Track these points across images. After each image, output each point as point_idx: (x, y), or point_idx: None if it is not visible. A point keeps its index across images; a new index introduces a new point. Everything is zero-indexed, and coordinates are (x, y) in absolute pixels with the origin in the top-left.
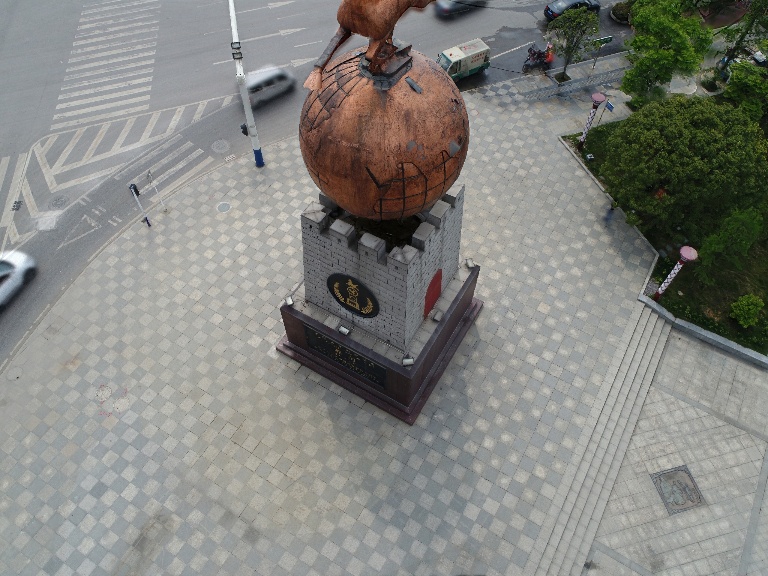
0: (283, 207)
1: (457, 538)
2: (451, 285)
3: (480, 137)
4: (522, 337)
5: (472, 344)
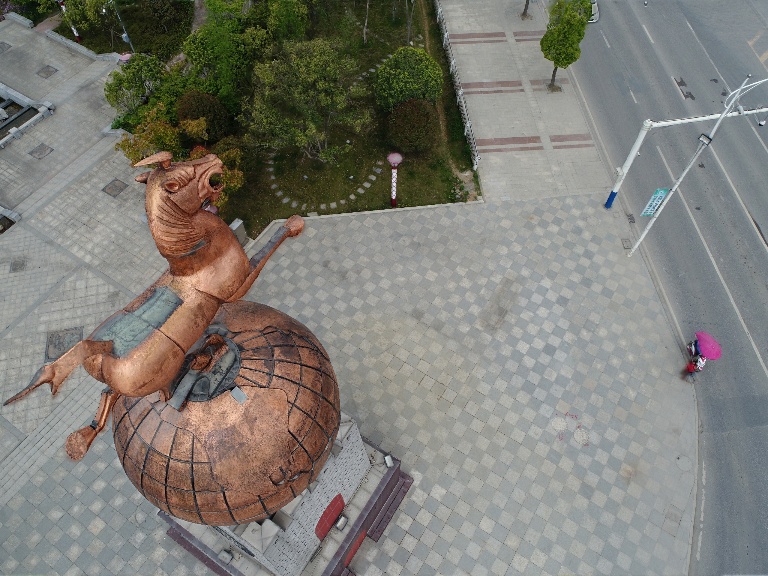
0: None
1: None
2: None
3: None
4: None
5: None
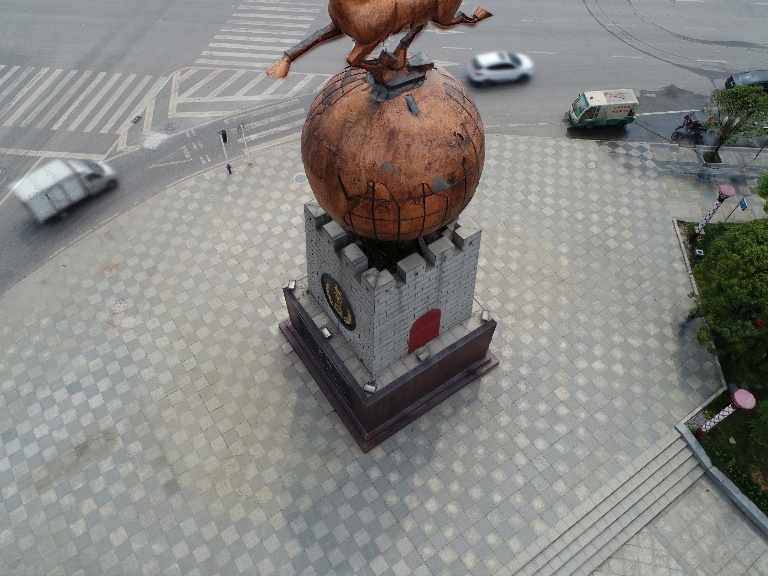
0: None
1: None
2: (455, 330)
3: (585, 192)
4: (523, 413)
5: (467, 399)
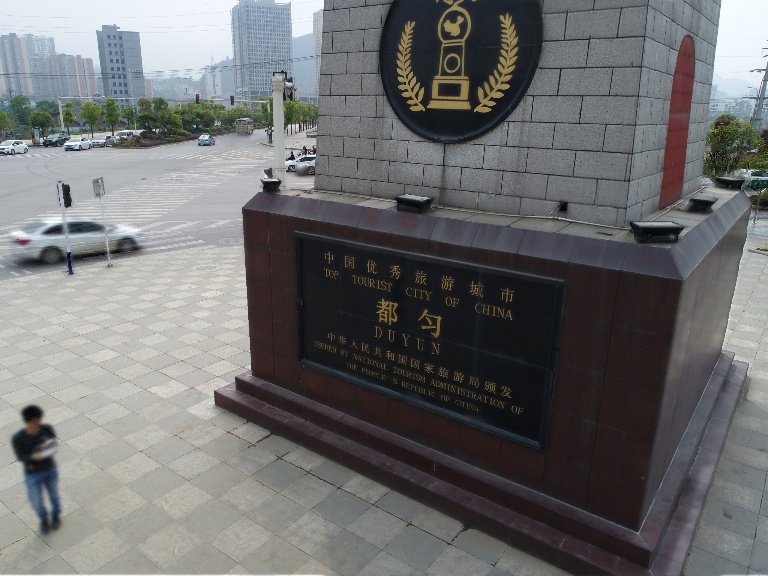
0: None
1: None
2: (700, 194)
3: None
4: None
5: (766, 430)
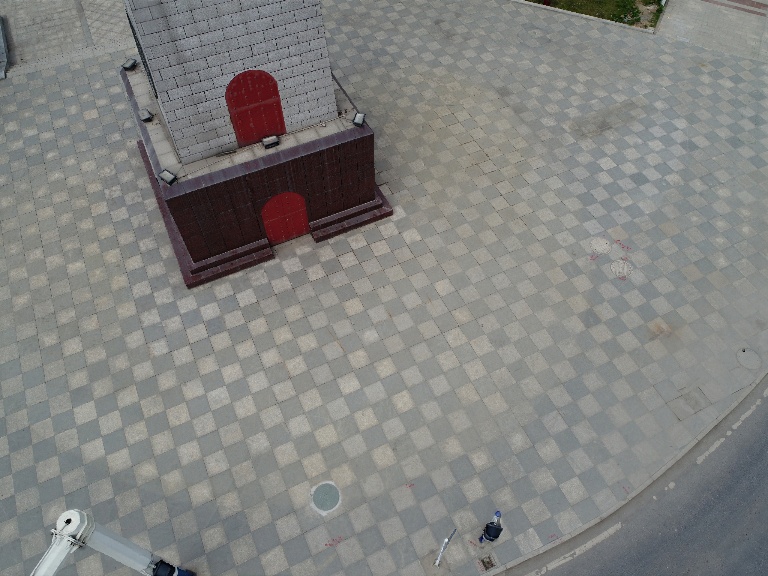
0: (230, 428)
1: (348, 29)
2: None
3: None
4: None
5: None
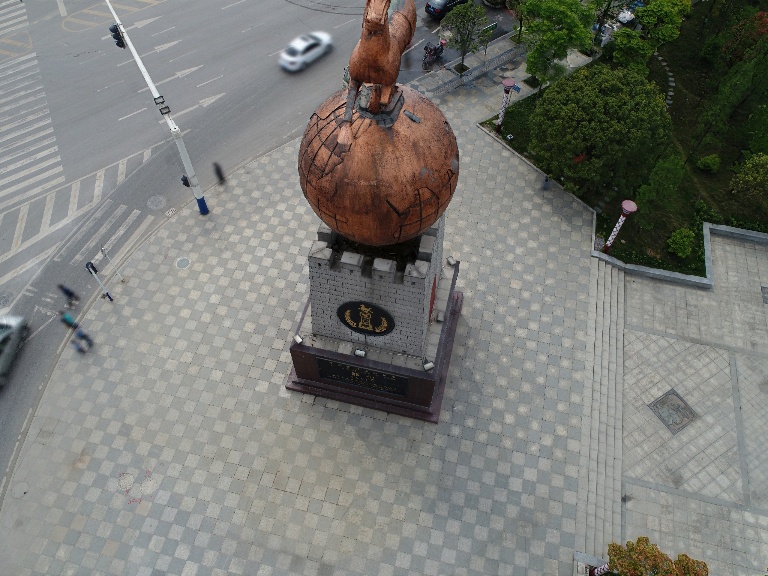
0: (243, 249)
1: (511, 512)
2: (441, 285)
3: None
4: (506, 315)
5: (465, 333)
